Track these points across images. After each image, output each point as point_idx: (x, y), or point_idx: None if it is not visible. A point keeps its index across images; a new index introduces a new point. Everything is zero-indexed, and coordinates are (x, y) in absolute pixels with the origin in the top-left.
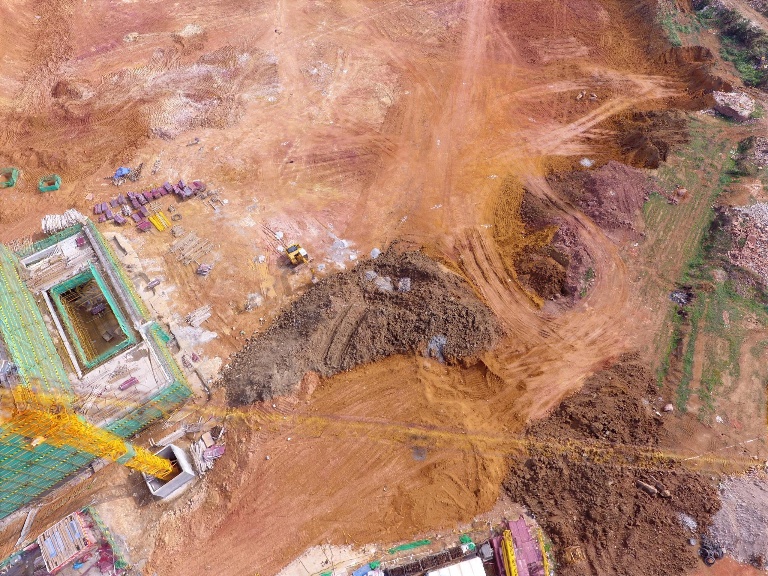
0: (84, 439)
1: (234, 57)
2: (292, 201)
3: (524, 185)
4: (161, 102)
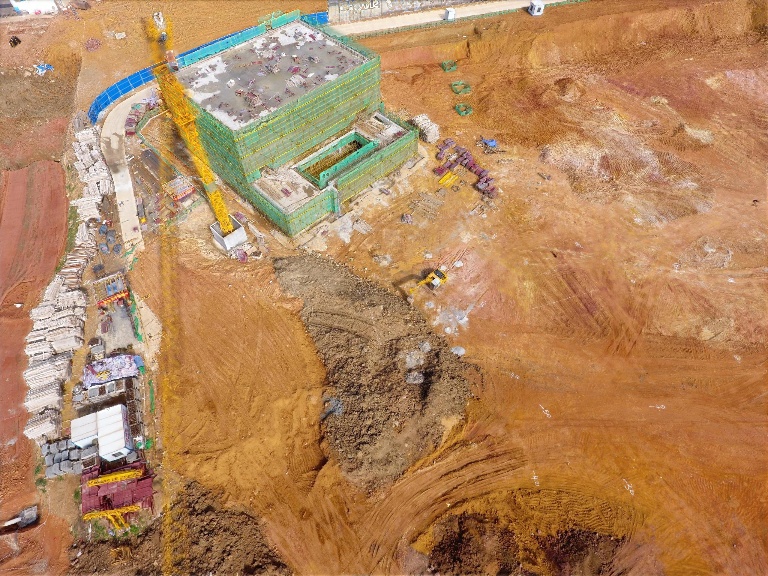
0: (246, 181)
1: (684, 176)
2: (503, 266)
3: (632, 538)
4: (585, 143)
